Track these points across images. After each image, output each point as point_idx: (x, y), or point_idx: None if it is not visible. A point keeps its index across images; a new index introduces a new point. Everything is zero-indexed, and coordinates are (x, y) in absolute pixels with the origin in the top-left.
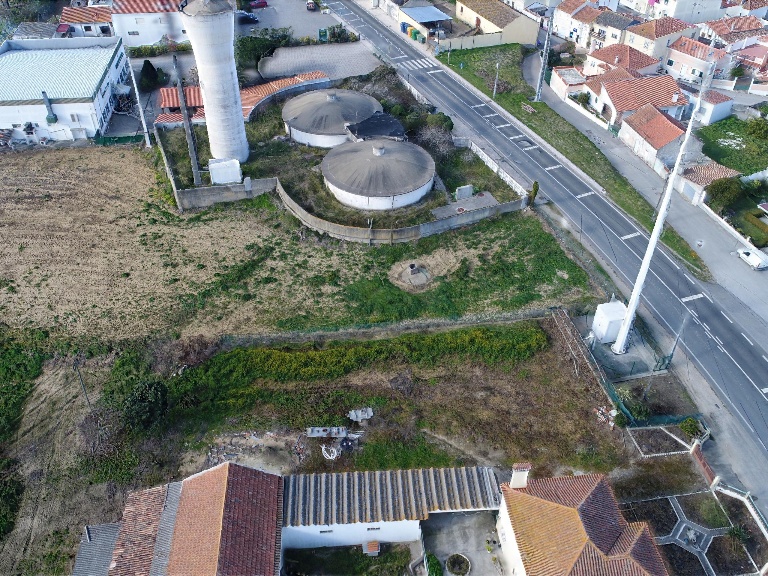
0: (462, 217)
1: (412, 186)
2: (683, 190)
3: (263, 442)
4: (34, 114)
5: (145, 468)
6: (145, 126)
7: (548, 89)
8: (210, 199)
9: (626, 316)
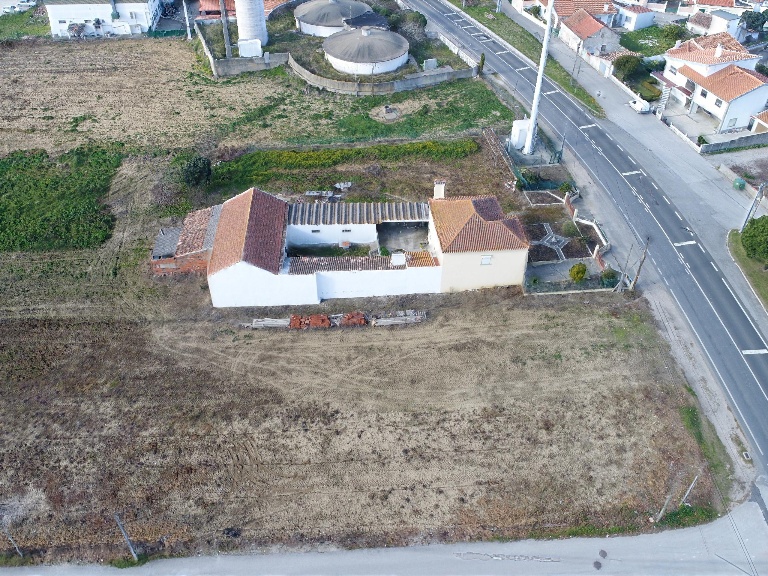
0: (426, 78)
1: (390, 57)
2: (599, 67)
3: None
4: (102, 12)
5: (196, 210)
6: (188, 21)
7: (510, 6)
8: (238, 68)
9: (530, 123)
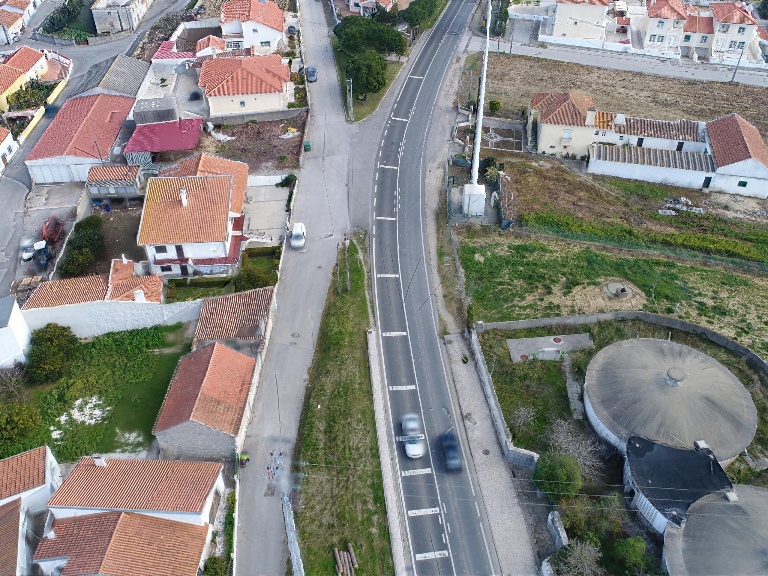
0: (562, 320)
1: (624, 346)
2: None
3: (734, 214)
4: None
5: None
6: None
7: None
8: None
9: None
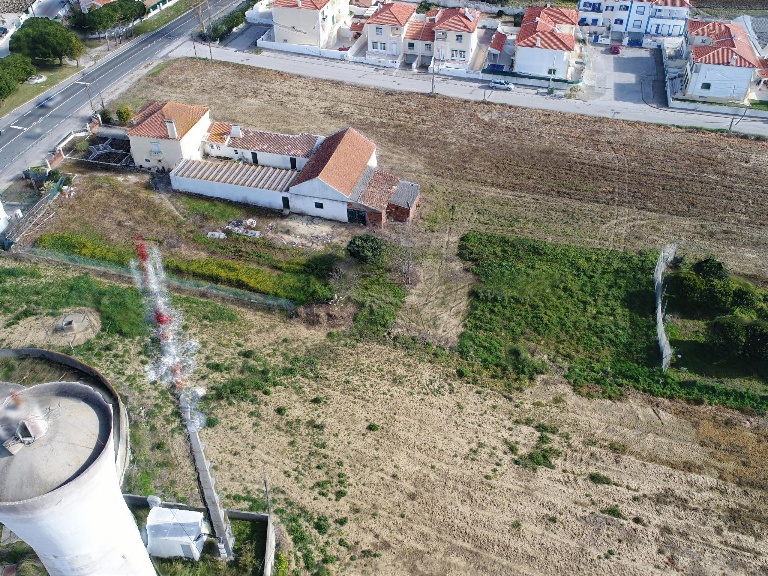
0: None
1: None
2: None
3: (292, 238)
4: None
5: None
6: None
7: None
8: None
9: None
